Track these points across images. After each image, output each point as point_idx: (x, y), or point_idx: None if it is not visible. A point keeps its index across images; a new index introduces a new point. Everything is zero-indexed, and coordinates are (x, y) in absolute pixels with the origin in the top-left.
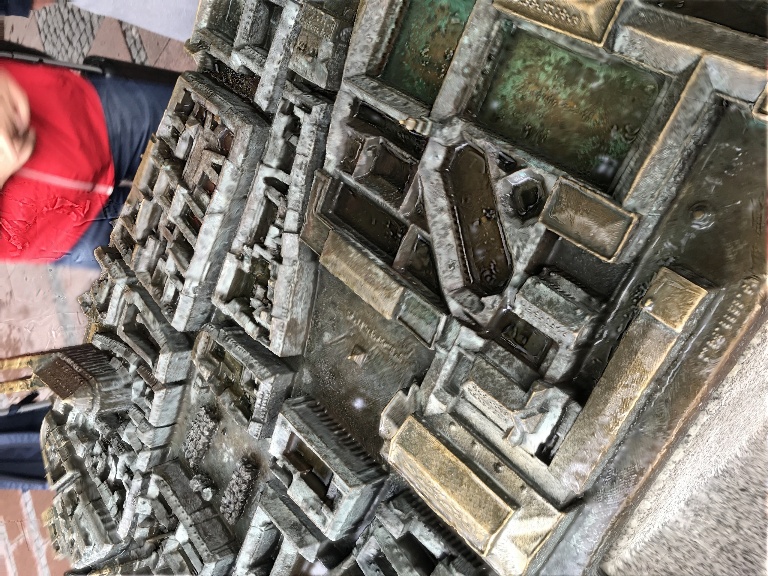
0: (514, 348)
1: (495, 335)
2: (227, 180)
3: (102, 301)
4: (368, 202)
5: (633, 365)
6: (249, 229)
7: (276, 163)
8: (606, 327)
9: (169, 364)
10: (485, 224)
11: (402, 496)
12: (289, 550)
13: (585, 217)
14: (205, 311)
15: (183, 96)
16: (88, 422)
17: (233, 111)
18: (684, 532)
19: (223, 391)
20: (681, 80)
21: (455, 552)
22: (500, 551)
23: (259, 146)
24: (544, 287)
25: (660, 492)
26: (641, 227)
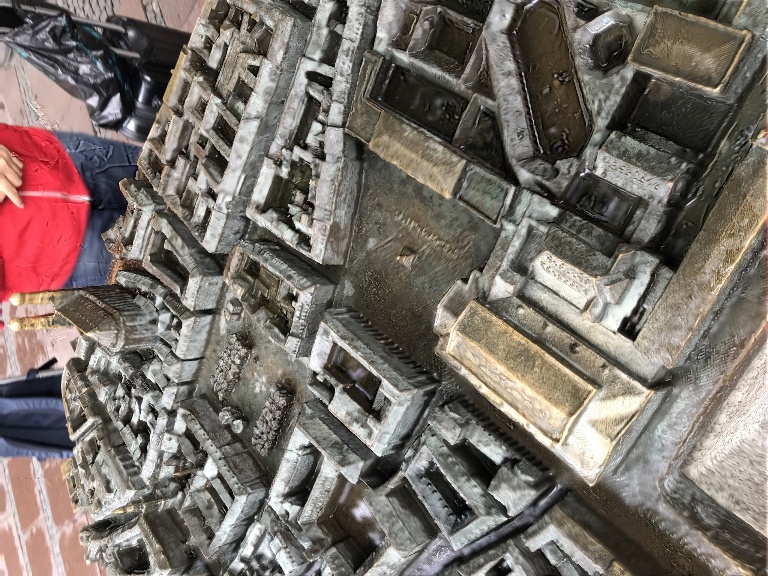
0: (592, 217)
1: (570, 206)
2: (265, 81)
3: (127, 235)
4: (423, 82)
5: (740, 211)
6: (288, 131)
7: (319, 55)
8: (701, 183)
9: (199, 289)
10: (557, 89)
11: (457, 401)
12: (329, 472)
13: (685, 45)
14: (238, 231)
15: (217, 1)
16: (110, 366)
17: (273, 6)
18: (763, 450)
19: (258, 309)
20: None
21: (519, 456)
22: (577, 439)
23: (300, 44)
24: (631, 140)
25: (752, 382)
26: (752, 50)
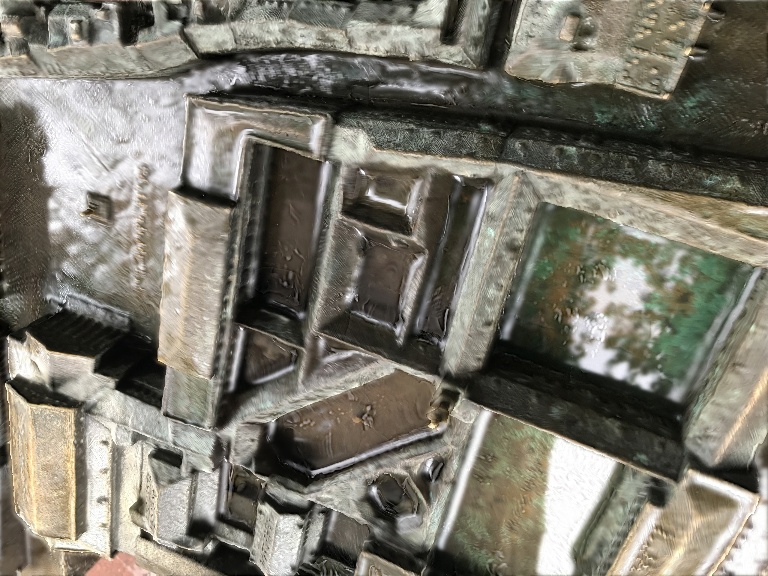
0: None
1: None
2: None
3: None
4: (314, 229)
5: None
6: None
7: None
8: None
9: None
10: (352, 413)
11: None
12: None
13: None
14: None
15: None
16: None
17: None
18: None
19: None
20: None
21: (2, 420)
22: None
23: None
24: (300, 531)
25: None
26: None
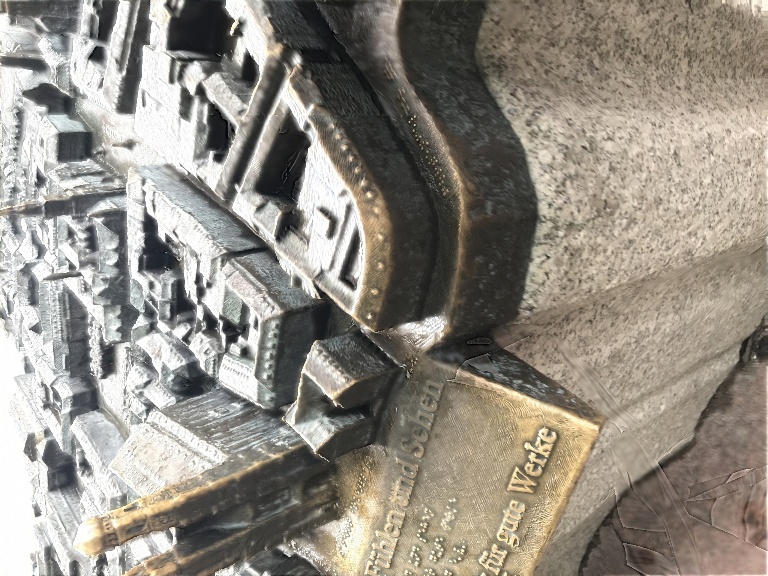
0: None
1: None
2: None
3: None
4: None
5: None
6: None
7: None
8: None
9: None
10: None
11: None
12: None
13: None
14: None
15: None
16: None
17: None
18: None
19: None
20: None
21: None
22: None
23: None
24: None
25: None
26: None
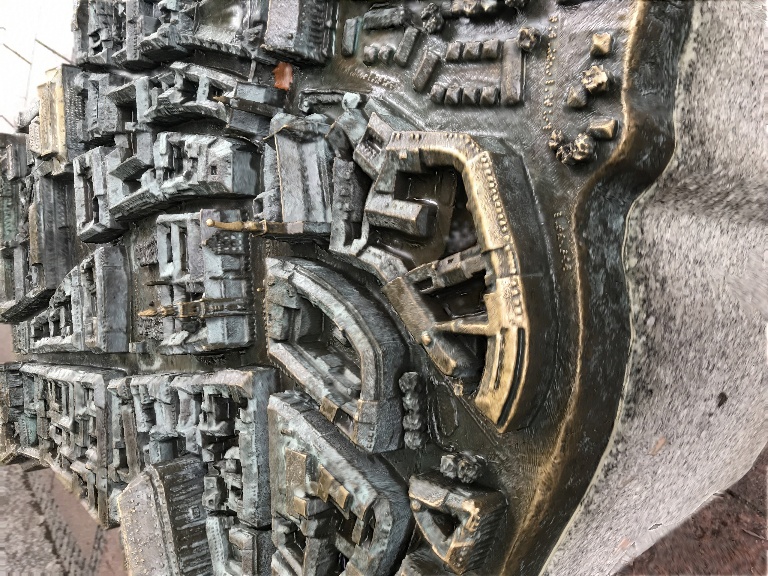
0: None
1: None
2: None
3: None
4: None
5: None
6: None
7: None
8: None
9: None
10: None
11: None
12: None
13: None
14: None
15: None
16: None
17: None
18: None
19: None
20: None
21: None
22: None
23: None
24: None
25: None
26: None
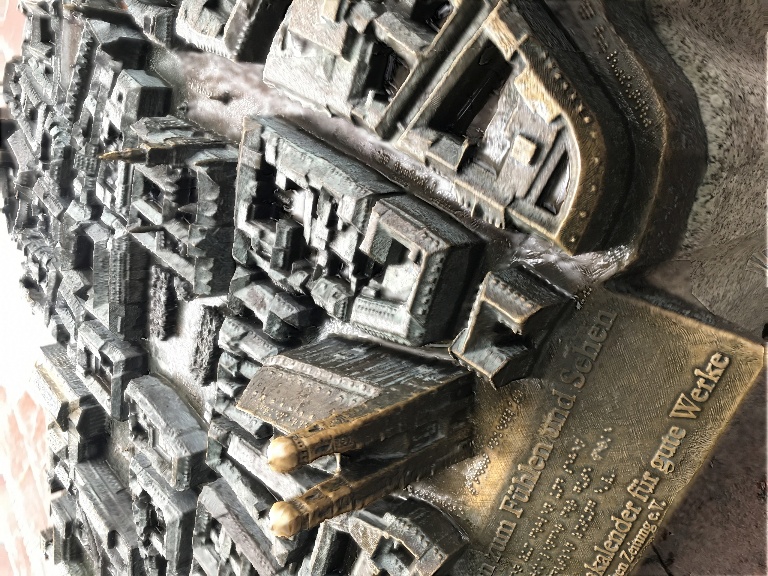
0: None
1: None
2: None
3: None
4: None
5: None
6: None
7: None
8: None
9: None
10: None
11: None
12: None
13: None
14: None
15: None
16: None
17: None
18: None
19: None
20: (59, 560)
21: None
22: None
23: None
24: None
25: None
26: None
